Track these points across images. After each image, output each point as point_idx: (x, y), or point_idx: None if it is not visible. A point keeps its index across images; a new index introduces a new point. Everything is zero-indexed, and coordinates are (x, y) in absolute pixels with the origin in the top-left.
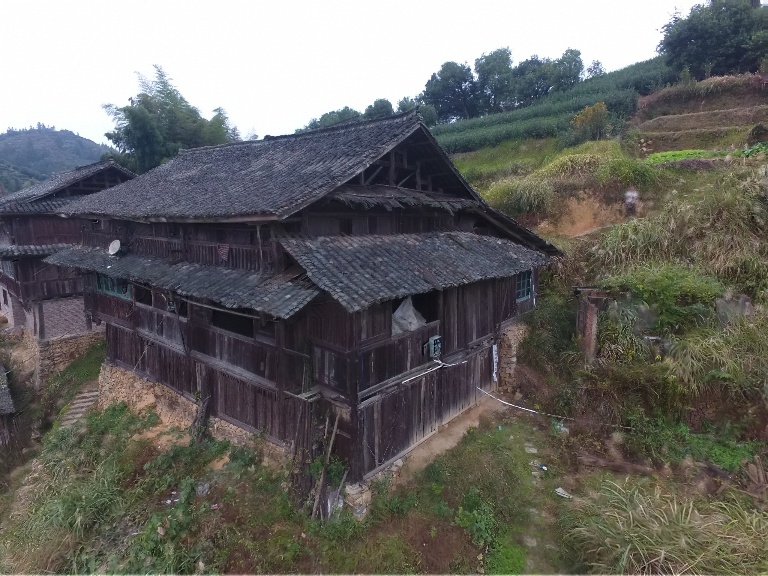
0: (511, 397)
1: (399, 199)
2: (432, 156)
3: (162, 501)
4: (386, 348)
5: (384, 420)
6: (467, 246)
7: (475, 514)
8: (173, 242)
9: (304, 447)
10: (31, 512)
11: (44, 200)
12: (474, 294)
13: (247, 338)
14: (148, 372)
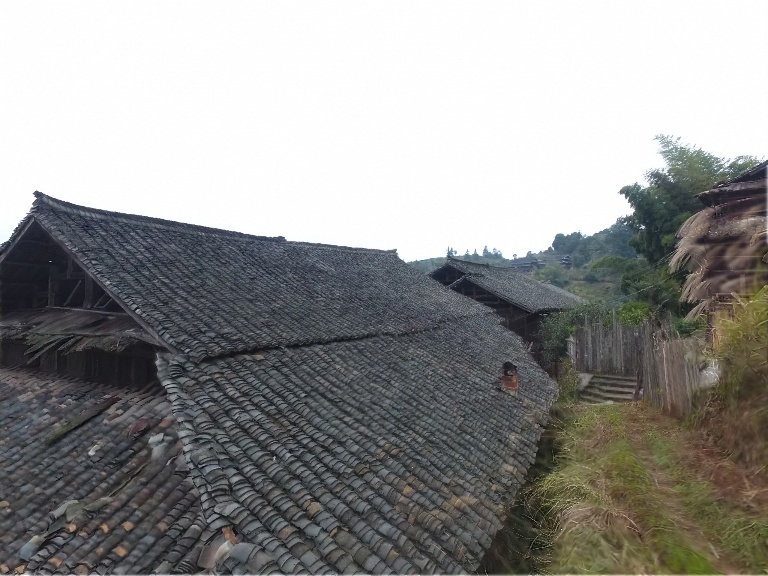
0: None
1: None
2: None
3: None
4: None
5: None
6: (59, 432)
7: None
8: None
9: None
10: None
11: None
12: None
13: None
14: None
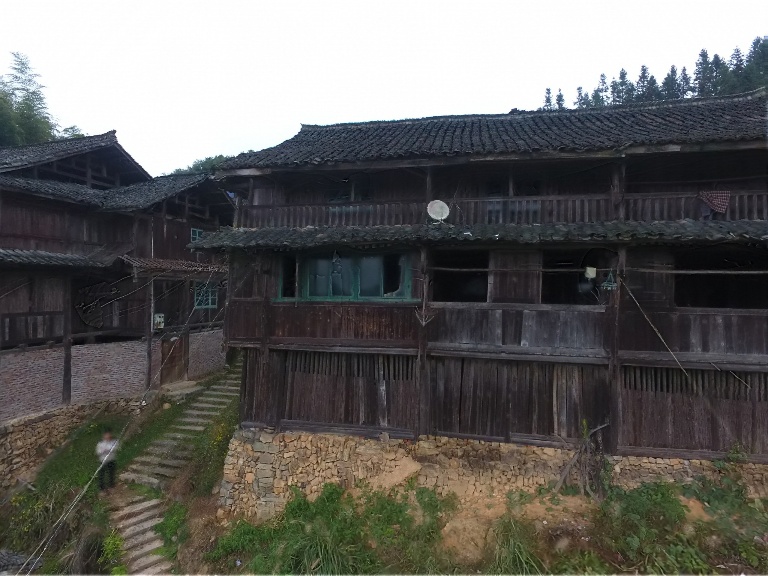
0: None
1: None
2: None
3: None
4: None
5: None
6: None
7: None
8: (569, 200)
9: None
10: None
11: (12, 176)
12: None
13: None
14: (386, 424)
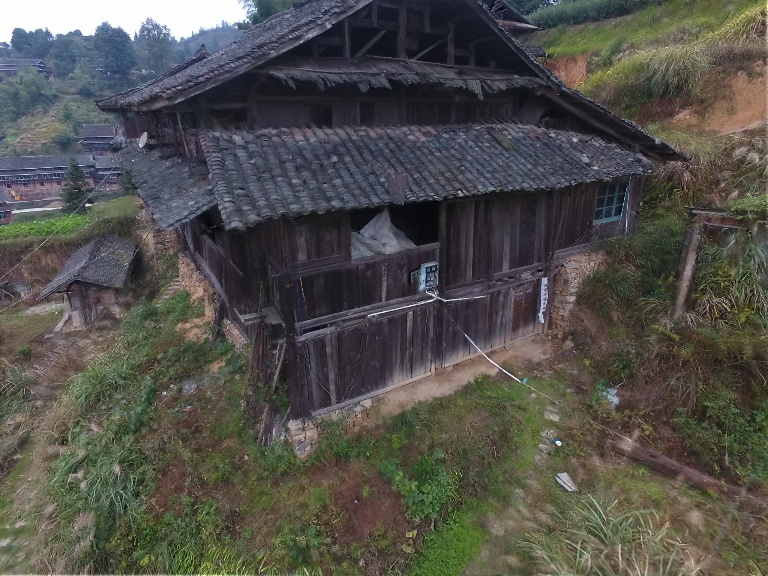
0: (559, 344)
1: (391, 76)
2: (466, 11)
3: (158, 392)
4: (343, 273)
5: (343, 355)
6: (508, 144)
7: (412, 486)
8: None
9: (259, 369)
10: None
11: None
12: (509, 210)
13: (213, 245)
14: None
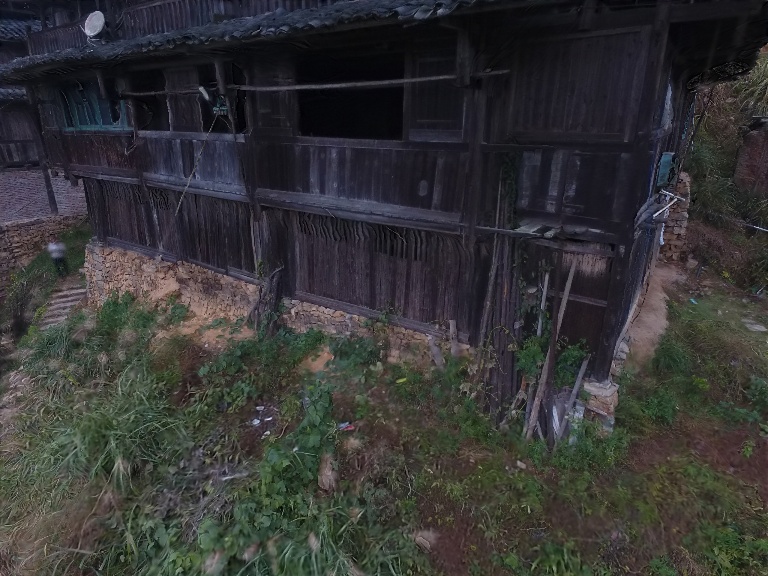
0: (681, 265)
1: None
2: None
3: (247, 422)
4: None
5: None
6: None
7: None
8: None
9: (502, 325)
10: (24, 447)
11: None
12: None
13: (387, 141)
14: (162, 248)
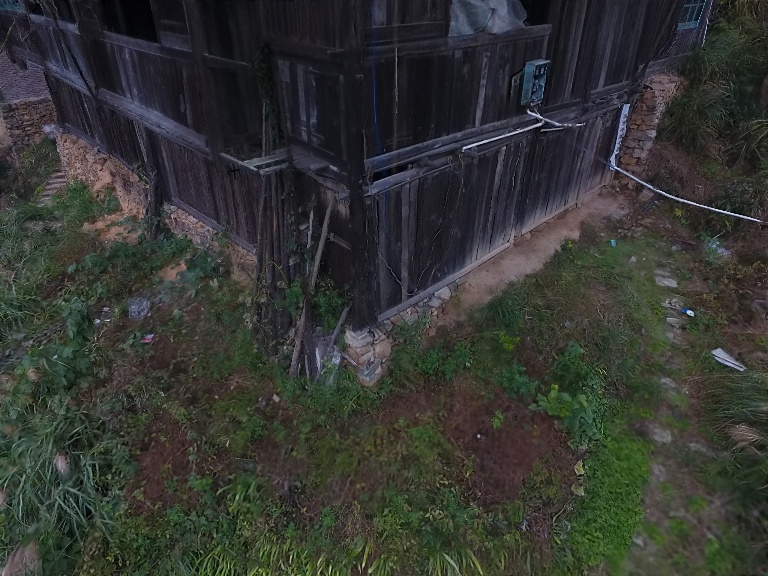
0: (633, 196)
1: None
2: None
3: None
4: (434, 63)
5: (421, 220)
6: None
7: (583, 403)
8: None
9: (274, 260)
10: None
11: None
12: None
13: (150, 44)
14: (97, 139)
